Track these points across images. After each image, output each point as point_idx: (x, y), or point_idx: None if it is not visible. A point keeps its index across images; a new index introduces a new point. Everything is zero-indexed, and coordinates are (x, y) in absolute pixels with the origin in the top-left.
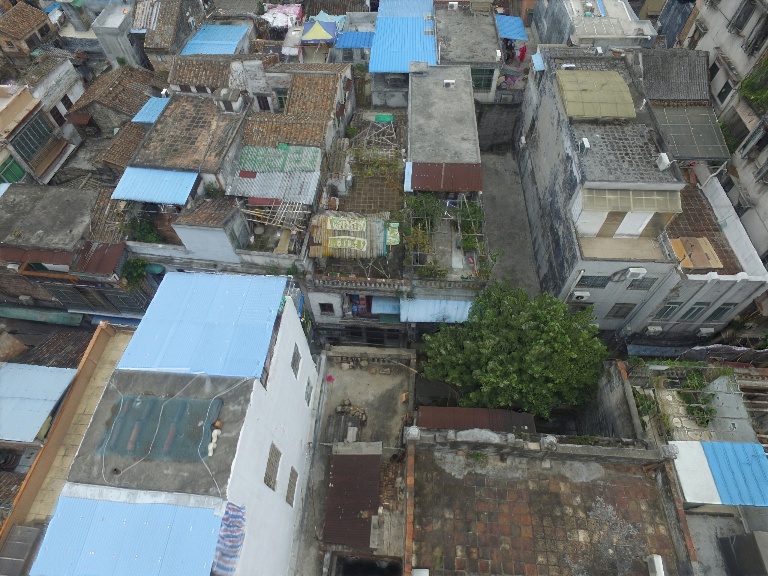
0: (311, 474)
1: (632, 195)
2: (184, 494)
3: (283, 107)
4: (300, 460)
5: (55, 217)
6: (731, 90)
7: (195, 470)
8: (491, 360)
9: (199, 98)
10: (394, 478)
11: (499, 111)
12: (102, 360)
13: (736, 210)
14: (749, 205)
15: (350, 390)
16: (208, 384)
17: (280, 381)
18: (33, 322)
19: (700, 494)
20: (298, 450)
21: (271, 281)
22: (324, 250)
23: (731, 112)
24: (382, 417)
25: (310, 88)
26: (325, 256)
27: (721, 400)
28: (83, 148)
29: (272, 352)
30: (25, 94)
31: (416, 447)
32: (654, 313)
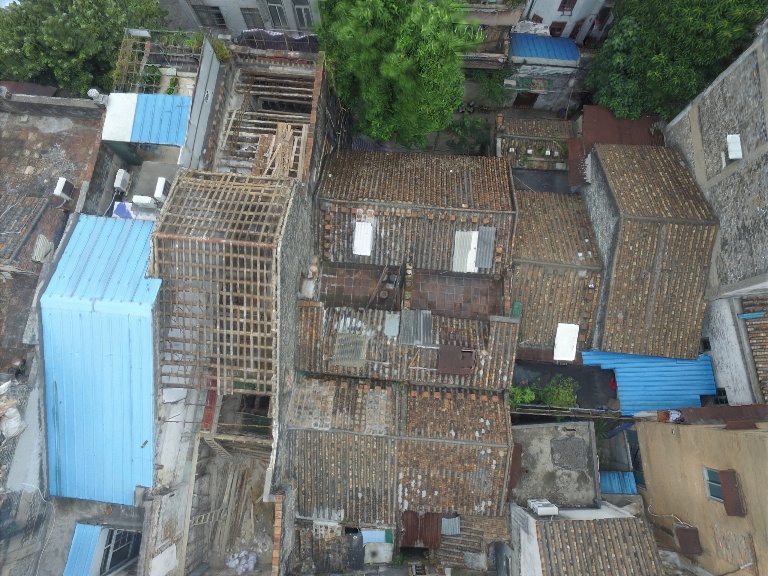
0: None
1: None
2: None
3: None
4: None
5: None
6: None
7: None
8: (9, 30)
9: None
10: None
11: None
12: None
13: None
14: None
15: None
16: None
17: None
18: None
19: (115, 134)
20: None
21: None
22: None
23: None
24: None
25: None
26: None
27: None
28: None
29: None
30: None
31: None
32: (266, 16)
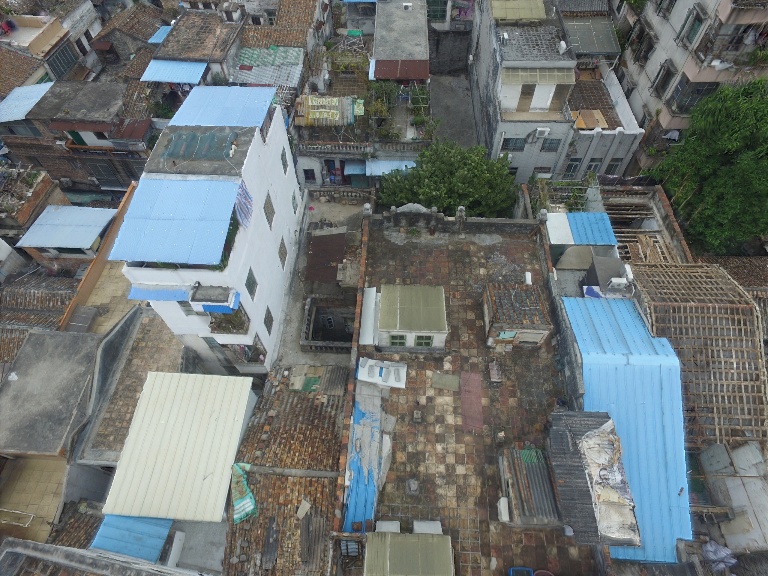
0: (297, 262)
1: (539, 72)
2: (216, 176)
3: None
4: (289, 244)
5: (94, 101)
6: (624, 2)
7: (222, 164)
8: None
9: (205, 13)
10: (355, 250)
11: (453, 38)
12: None
13: (627, 94)
14: (632, 85)
15: (326, 215)
16: (227, 129)
17: (273, 155)
18: None
19: (561, 239)
20: (287, 233)
21: (266, 89)
22: (306, 120)
23: (623, 19)
24: (350, 230)
25: (295, 6)
26: (307, 125)
27: None
28: (104, 73)
29: (268, 130)
30: (56, 23)
31: (370, 226)
32: (562, 171)
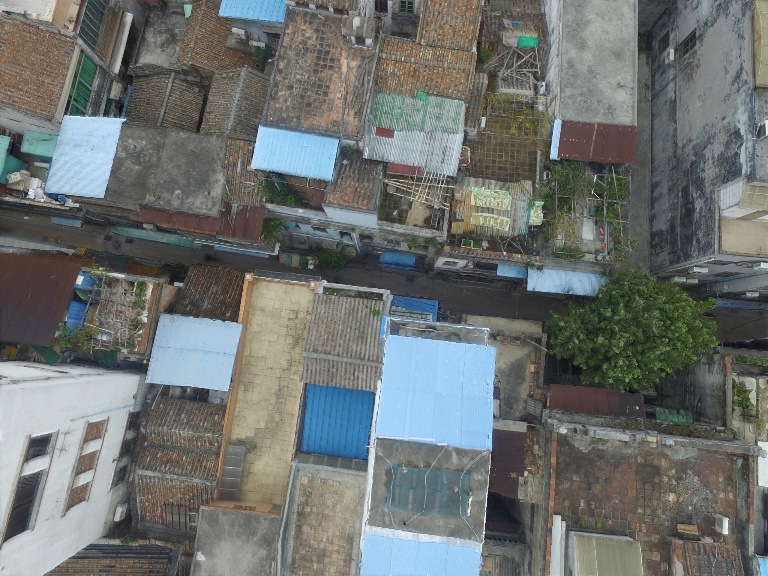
0: None
1: None
2: (452, 538)
3: (404, 11)
4: None
5: (187, 173)
6: None
7: (459, 524)
8: (620, 356)
9: (318, 17)
10: (532, 446)
11: (648, 1)
12: (252, 307)
13: None
14: None
15: None
16: (455, 457)
17: None
18: None
19: None
20: None
21: (482, 350)
22: (466, 226)
23: None
24: (513, 383)
25: (449, 4)
26: (466, 231)
27: None
28: (149, 27)
29: None
30: None
31: None
32: None
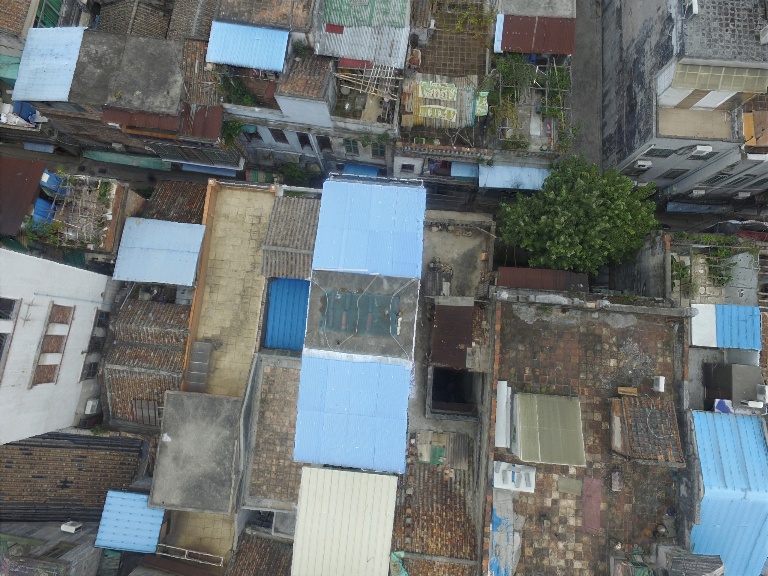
0: None
1: (724, 72)
2: (384, 357)
3: None
4: None
5: (146, 75)
6: None
7: (389, 343)
8: (563, 233)
9: None
10: (480, 321)
11: None
12: (217, 213)
13: None
14: None
15: (438, 249)
16: (385, 284)
17: None
18: (126, 166)
19: (704, 340)
20: None
21: (413, 192)
22: (415, 119)
23: None
24: (465, 271)
25: None
26: (415, 125)
27: (740, 270)
28: None
29: None
30: None
31: (501, 302)
32: (704, 181)
